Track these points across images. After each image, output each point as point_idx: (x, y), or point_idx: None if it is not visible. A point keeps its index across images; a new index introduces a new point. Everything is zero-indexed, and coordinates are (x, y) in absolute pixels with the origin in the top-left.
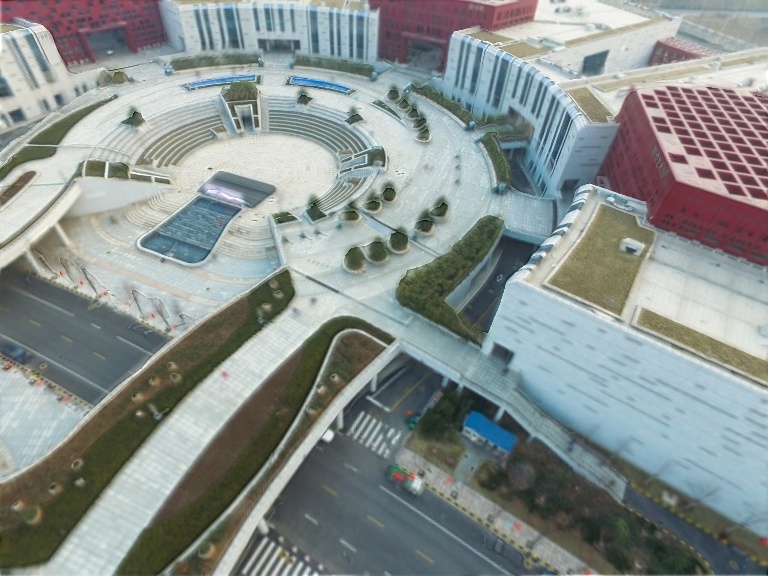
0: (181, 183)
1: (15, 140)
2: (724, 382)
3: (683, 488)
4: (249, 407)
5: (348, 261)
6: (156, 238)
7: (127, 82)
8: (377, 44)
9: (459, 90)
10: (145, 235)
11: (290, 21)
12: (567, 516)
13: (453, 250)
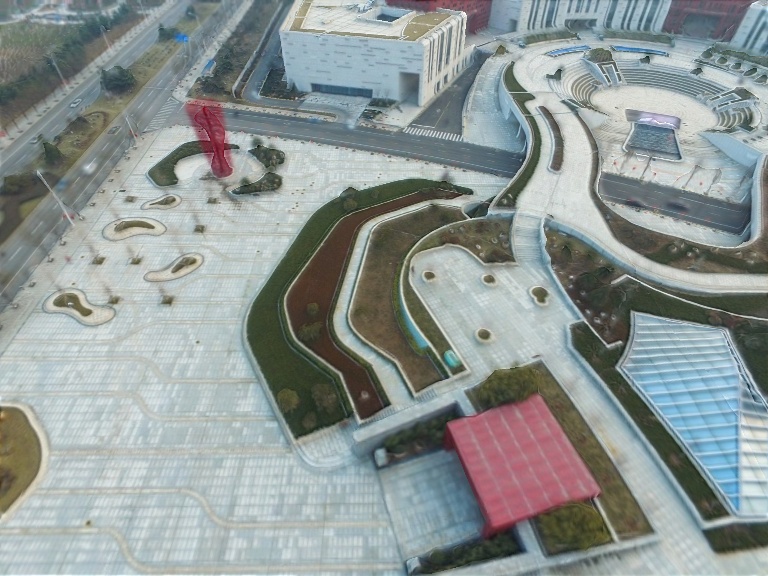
0: None
1: (471, 93)
2: None
3: None
4: None
5: None
6: (631, 148)
7: (506, 53)
8: (665, 19)
9: (747, 50)
10: (625, 146)
11: (595, 4)
12: None
13: None
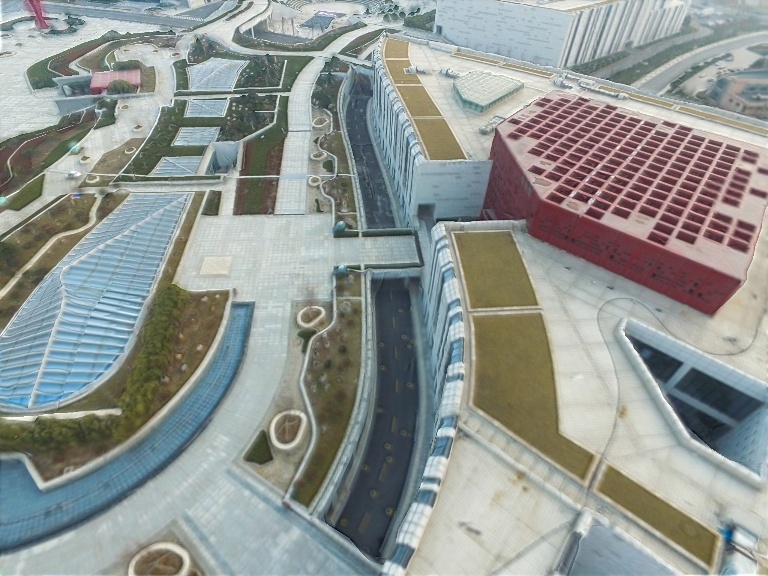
0: (305, 13)
1: (226, 2)
2: (491, 2)
3: None
4: None
5: (384, 19)
6: (304, 26)
7: None
8: None
9: None
10: (300, 24)
11: None
12: None
13: (423, 14)
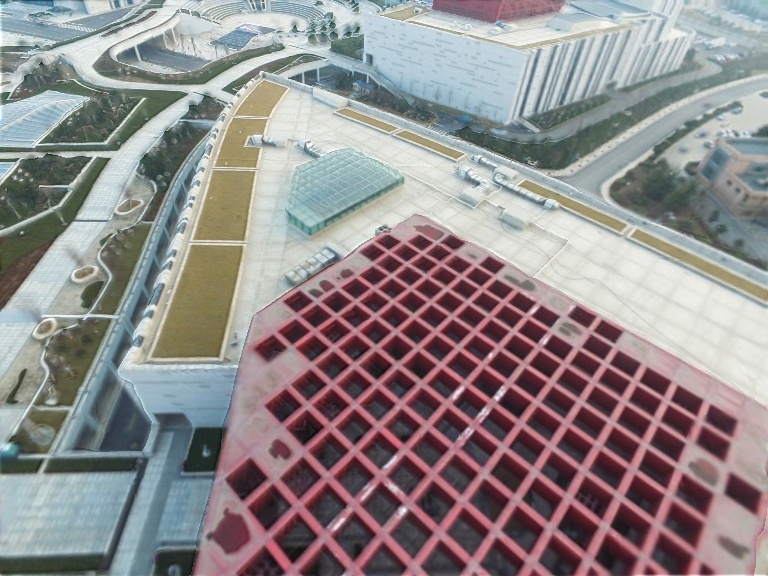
0: (226, 26)
1: (134, 8)
2: (427, 30)
3: (434, 98)
4: (268, 64)
5: (309, 40)
6: None
7: None
8: None
9: None
10: (212, 41)
11: None
12: (388, 104)
13: None
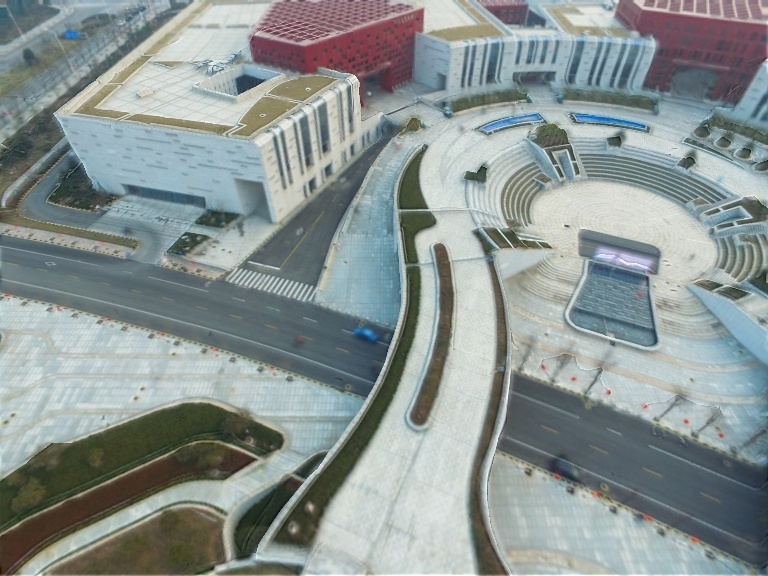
0: (554, 245)
1: (355, 200)
2: None
3: None
4: None
5: None
6: (579, 314)
7: (421, 128)
8: (646, 73)
9: (758, 121)
10: (569, 311)
11: (553, 52)
12: None
13: None
